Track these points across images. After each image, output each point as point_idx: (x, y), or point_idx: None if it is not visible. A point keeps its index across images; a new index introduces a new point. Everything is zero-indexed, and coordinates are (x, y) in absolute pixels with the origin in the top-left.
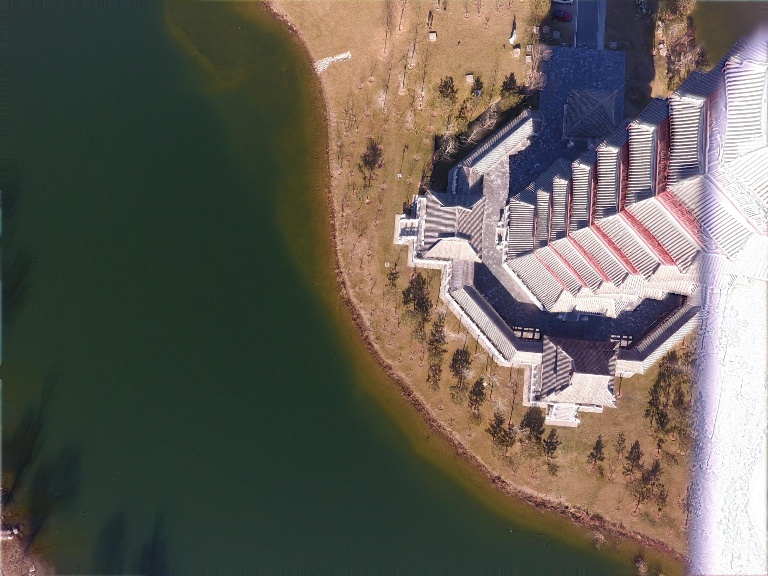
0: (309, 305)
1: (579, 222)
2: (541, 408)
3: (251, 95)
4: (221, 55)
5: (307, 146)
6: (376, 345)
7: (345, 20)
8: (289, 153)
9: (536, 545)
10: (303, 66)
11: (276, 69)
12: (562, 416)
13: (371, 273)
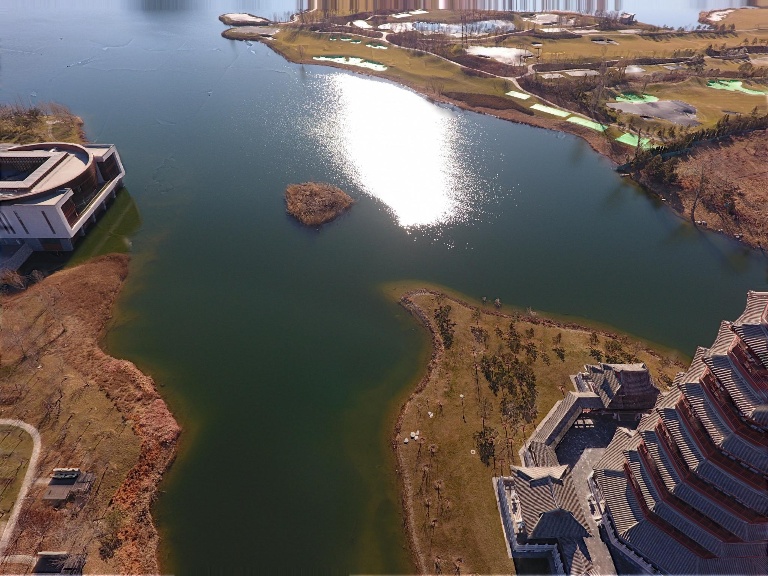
0: None
1: None
2: None
3: None
4: None
5: None
6: None
7: None
8: None
9: None
10: None
11: None
12: None
13: None
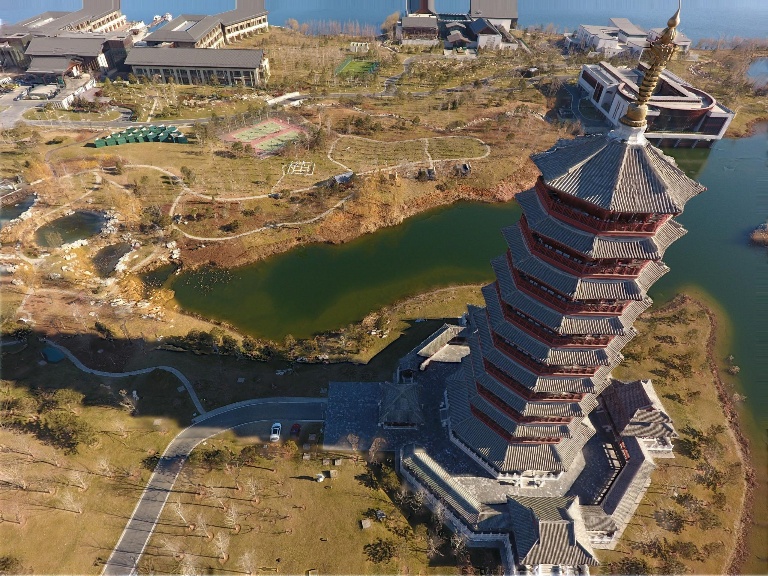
0: None
1: (584, 386)
2: None
3: None
4: None
5: None
6: None
7: None
8: None
9: None
10: None
11: None
12: None
13: None
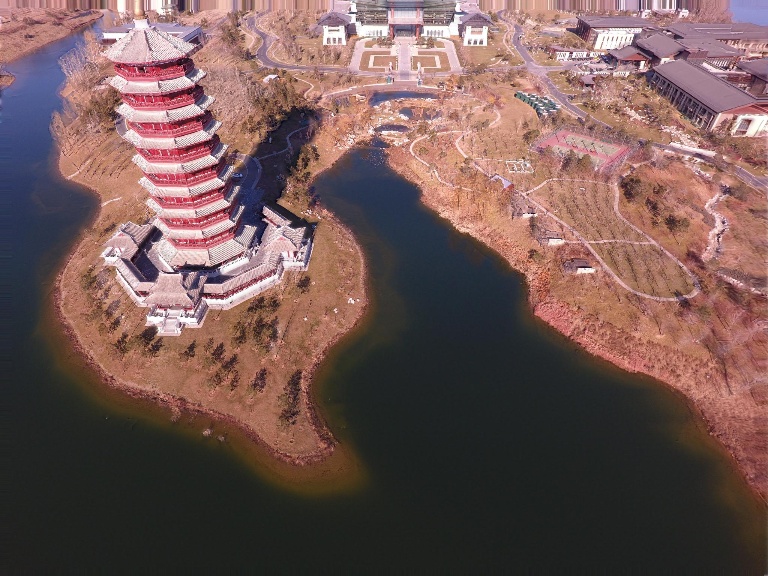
0: (31, 294)
1: None
2: (157, 327)
3: (60, 216)
4: (54, 204)
5: (78, 231)
6: (62, 307)
7: (125, 188)
8: (66, 234)
9: (124, 428)
10: (96, 205)
11: (81, 207)
12: (170, 329)
13: (79, 272)
